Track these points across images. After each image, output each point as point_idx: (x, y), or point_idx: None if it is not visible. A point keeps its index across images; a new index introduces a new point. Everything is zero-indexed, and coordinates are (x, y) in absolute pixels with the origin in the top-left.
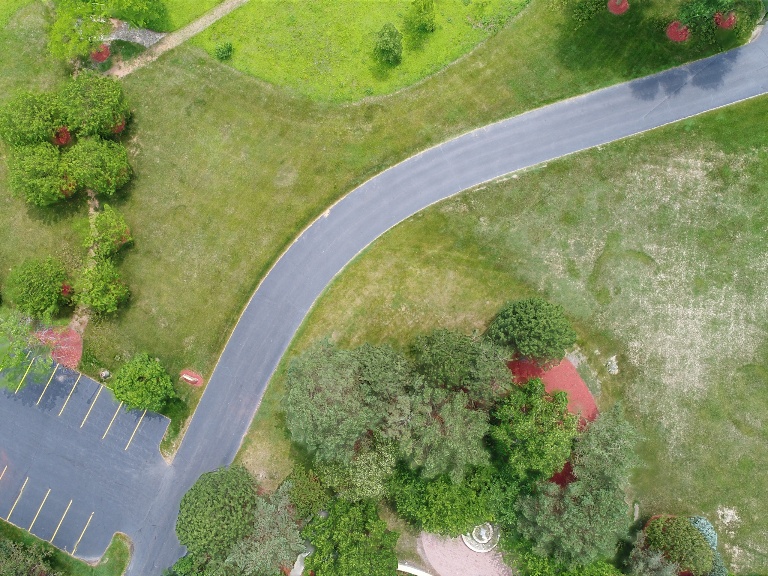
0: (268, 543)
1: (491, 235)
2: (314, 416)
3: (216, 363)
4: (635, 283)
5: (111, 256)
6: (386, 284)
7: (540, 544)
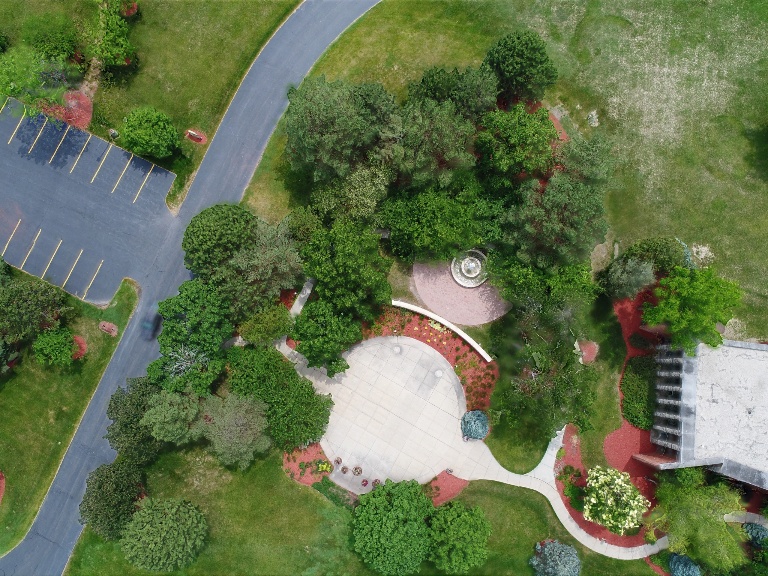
0: (269, 254)
1: (478, 3)
2: (312, 112)
3: (219, 123)
4: (614, 45)
5: (120, 18)
6: (380, 46)
7: (524, 247)
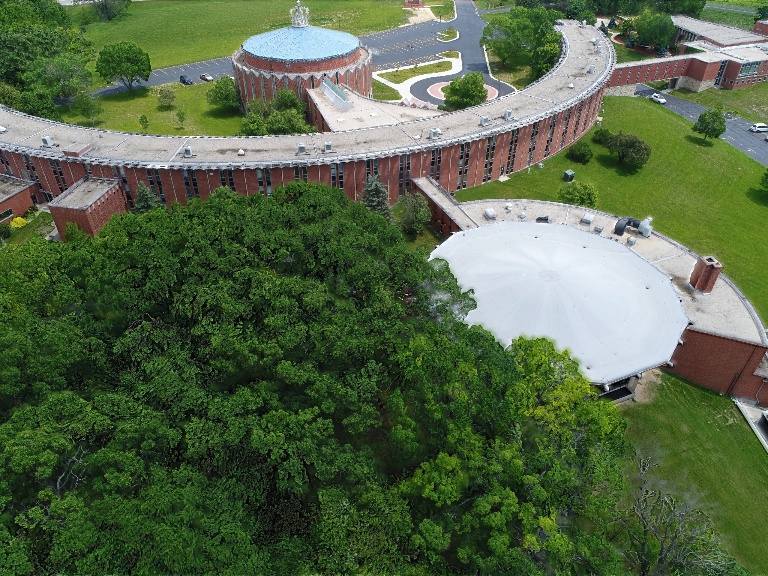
0: None
1: None
2: None
3: None
4: None
5: None
6: None
7: None
